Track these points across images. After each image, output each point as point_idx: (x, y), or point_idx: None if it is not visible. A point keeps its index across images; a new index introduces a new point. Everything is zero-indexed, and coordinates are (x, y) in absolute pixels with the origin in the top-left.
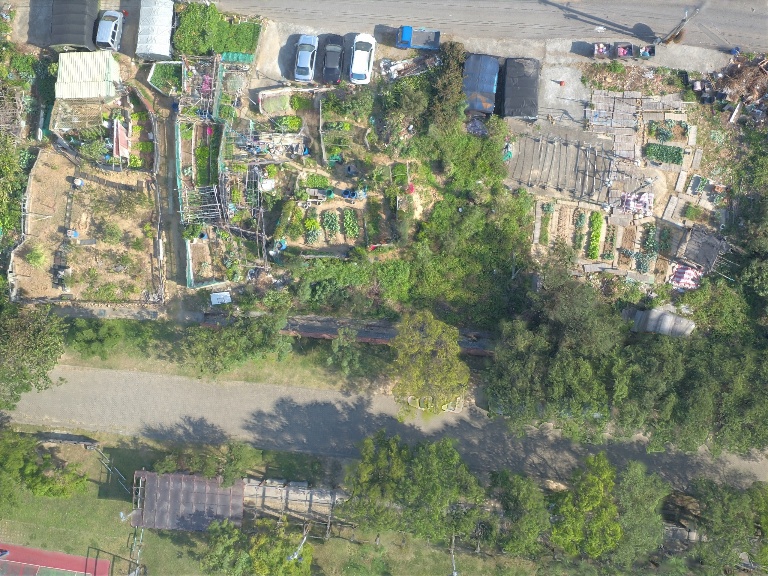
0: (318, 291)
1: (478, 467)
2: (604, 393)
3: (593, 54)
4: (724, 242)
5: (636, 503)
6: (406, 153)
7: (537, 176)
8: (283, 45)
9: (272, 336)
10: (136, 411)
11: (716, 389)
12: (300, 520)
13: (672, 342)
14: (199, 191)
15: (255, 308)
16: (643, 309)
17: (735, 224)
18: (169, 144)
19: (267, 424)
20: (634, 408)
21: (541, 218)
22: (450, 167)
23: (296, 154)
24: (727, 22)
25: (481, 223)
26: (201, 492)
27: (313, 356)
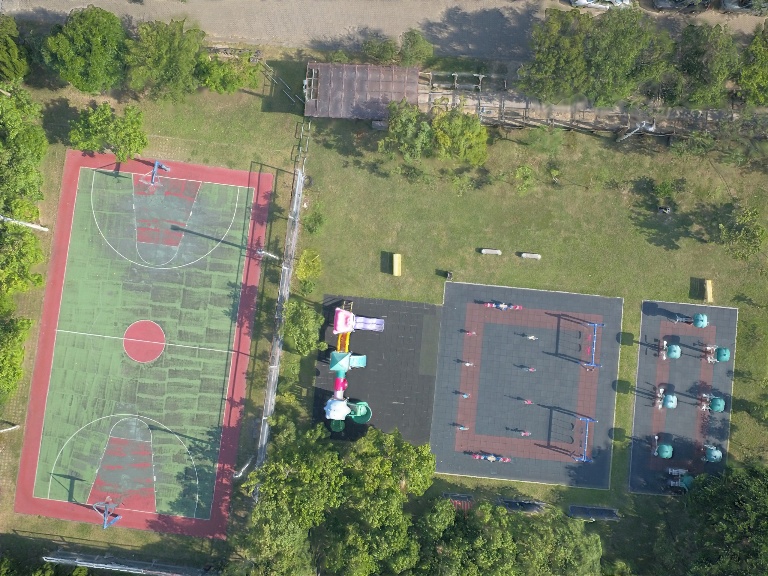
0: None
1: None
2: None
3: None
4: None
5: None
6: None
7: None
8: None
9: None
10: (299, 23)
11: None
12: None
13: None
14: None
15: None
16: None
17: None
18: None
19: (432, 31)
20: None
21: None
22: None
23: None
24: None
25: None
26: (375, 80)
27: None
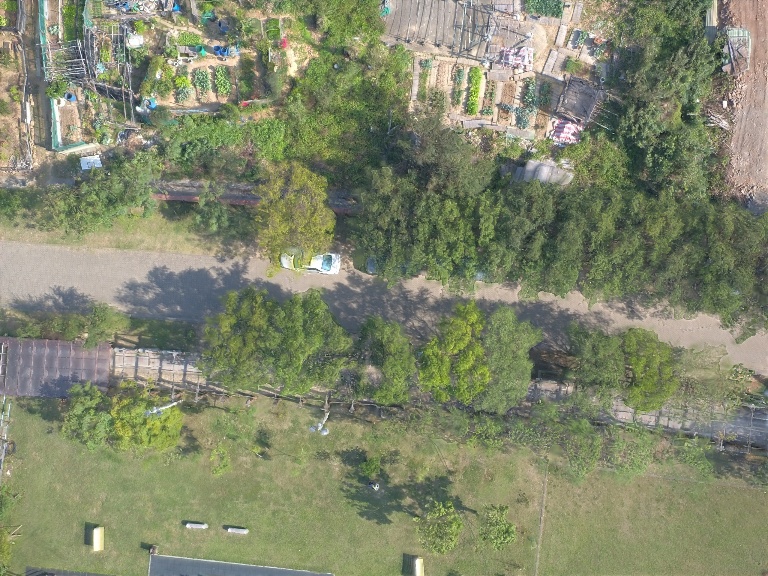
0: (188, 149)
1: (357, 331)
2: (471, 234)
3: None
4: (601, 91)
5: (504, 346)
6: (278, 7)
7: (415, 32)
8: None
9: (133, 187)
10: (4, 281)
11: (585, 228)
12: (174, 390)
13: (544, 186)
14: (62, 46)
15: None
16: (523, 165)
17: (615, 77)
18: (36, 4)
19: (139, 292)
20: (501, 248)
21: (419, 74)
22: (322, 19)
23: (167, 11)
24: None
25: (357, 80)
26: (65, 357)
27: (187, 220)
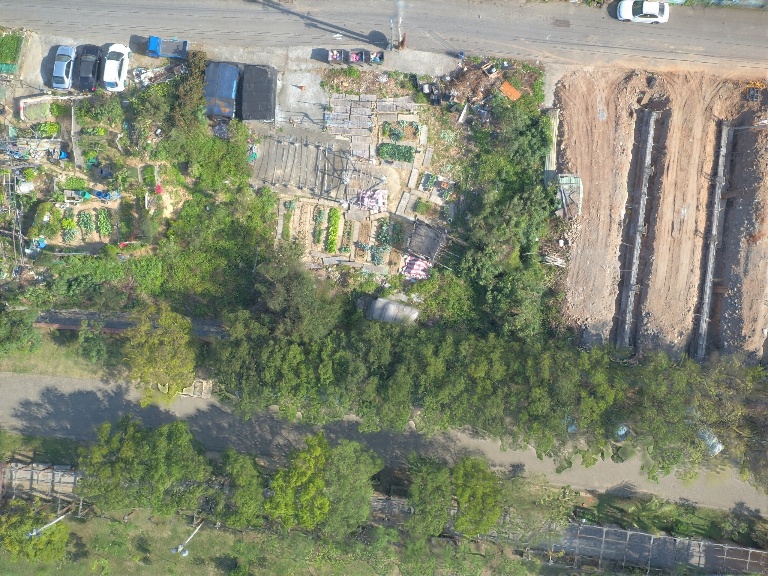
0: (73, 286)
1: (228, 449)
2: (313, 377)
3: (328, 60)
4: (444, 235)
5: (342, 478)
6: (155, 156)
7: (280, 175)
8: (45, 56)
9: (17, 329)
10: None
11: (416, 371)
12: (65, 501)
13: (384, 329)
14: None
15: (22, 303)
16: None
17: (462, 218)
18: None
19: (34, 412)
20: (340, 390)
21: (283, 215)
22: (192, 168)
23: None
24: (455, 28)
25: (227, 220)
26: None
27: (75, 347)
